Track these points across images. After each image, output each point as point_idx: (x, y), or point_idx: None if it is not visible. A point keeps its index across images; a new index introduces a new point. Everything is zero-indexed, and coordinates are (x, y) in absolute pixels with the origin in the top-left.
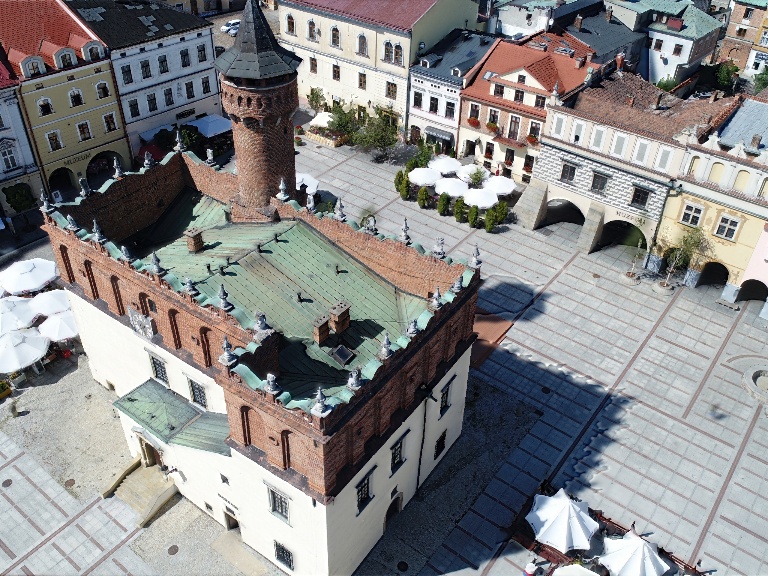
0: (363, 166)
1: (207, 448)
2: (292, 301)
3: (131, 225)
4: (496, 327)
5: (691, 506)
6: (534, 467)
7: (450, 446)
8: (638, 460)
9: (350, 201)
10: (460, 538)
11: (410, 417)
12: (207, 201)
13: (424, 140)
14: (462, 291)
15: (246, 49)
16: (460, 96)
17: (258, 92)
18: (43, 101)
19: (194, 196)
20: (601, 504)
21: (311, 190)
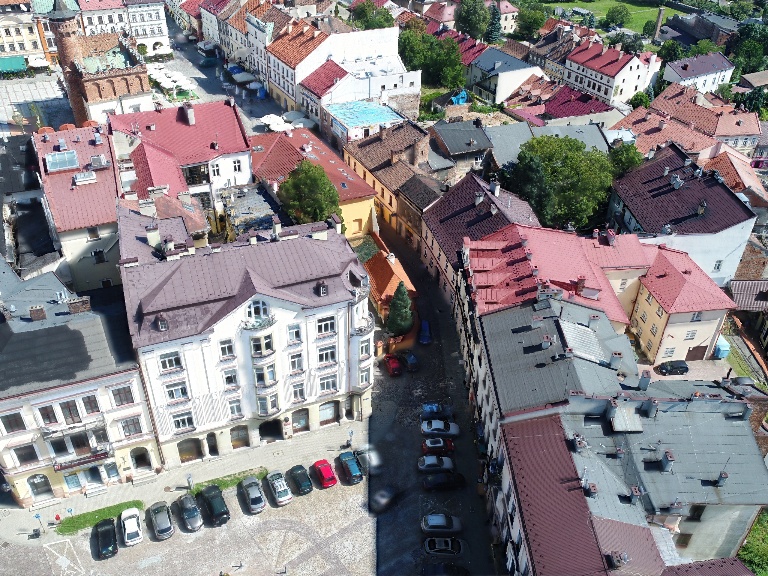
0: None
1: None
2: None
3: None
4: None
5: None
6: None
7: None
8: None
9: None
10: None
11: None
12: None
13: None
14: None
15: None
16: None
17: None
18: None
19: None
20: None
21: None
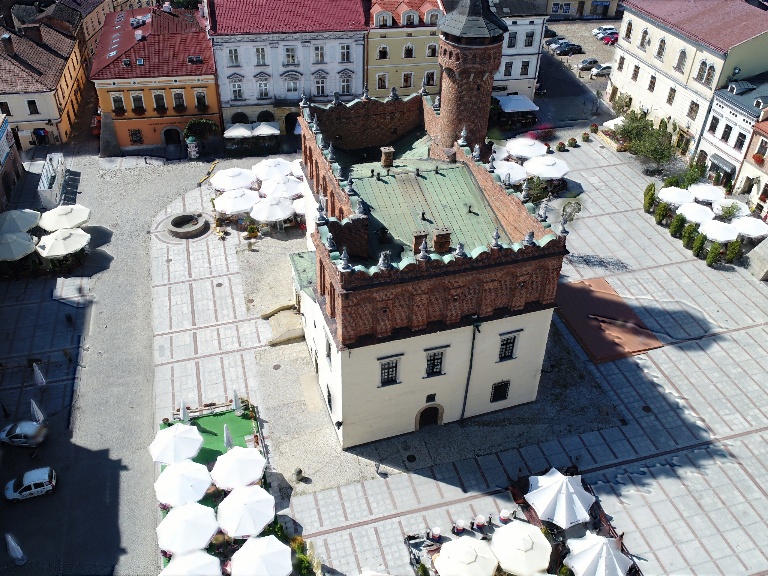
0: (630, 173)
1: (312, 296)
2: (417, 217)
3: (365, 140)
4: (643, 341)
5: (710, 565)
6: (580, 456)
7: (518, 404)
8: (689, 503)
9: (593, 197)
10: (471, 466)
11: (453, 335)
12: (427, 139)
13: (708, 167)
14: (535, 248)
15: (461, 12)
16: (753, 129)
17: (458, 48)
18: (383, 48)
19: (421, 133)
20: (617, 513)
21: (557, 174)
